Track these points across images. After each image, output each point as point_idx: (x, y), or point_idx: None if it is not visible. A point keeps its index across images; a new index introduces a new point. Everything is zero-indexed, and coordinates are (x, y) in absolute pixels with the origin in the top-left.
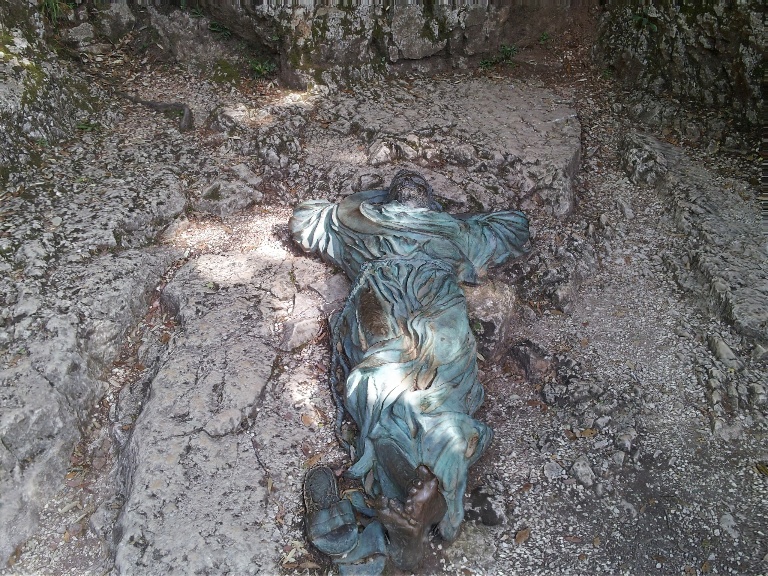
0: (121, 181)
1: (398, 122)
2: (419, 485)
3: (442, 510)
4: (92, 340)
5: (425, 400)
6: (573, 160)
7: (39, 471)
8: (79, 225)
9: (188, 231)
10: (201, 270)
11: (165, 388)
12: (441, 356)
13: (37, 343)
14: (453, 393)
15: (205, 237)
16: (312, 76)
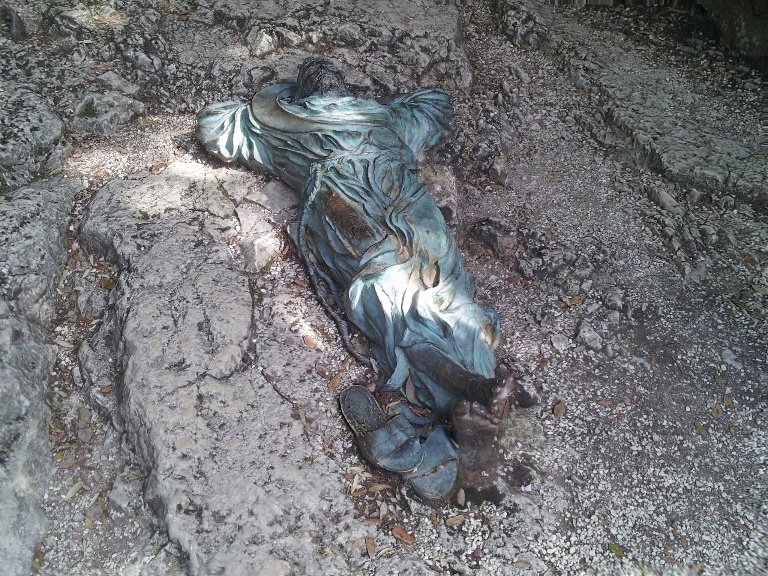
0: None
1: (267, 5)
2: (503, 383)
3: None
4: (22, 300)
5: (437, 297)
6: (457, 29)
7: (24, 460)
8: None
9: (74, 157)
10: (119, 199)
11: (145, 338)
12: (434, 249)
13: None
14: (457, 285)
15: (98, 161)
16: None
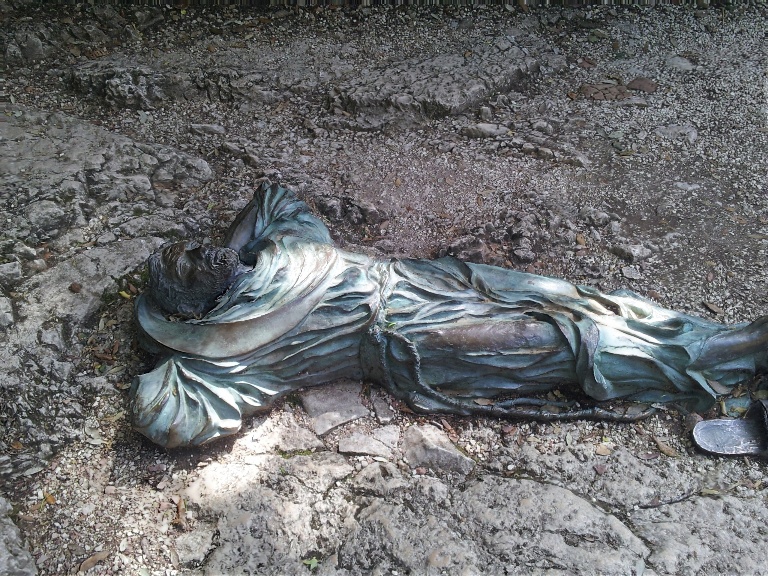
0: None
1: None
2: None
3: None
4: None
5: None
6: None
7: None
8: None
9: None
10: None
11: None
12: (560, 288)
13: None
14: None
15: None
16: None
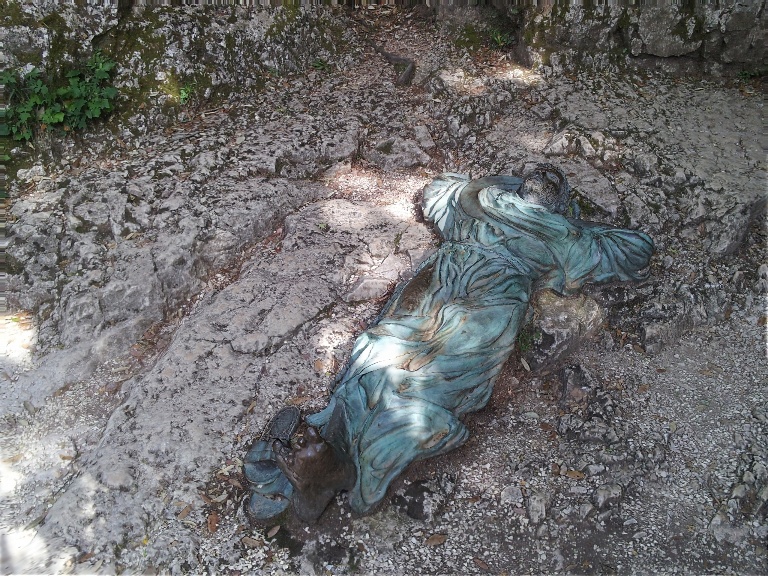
0: (311, 118)
1: (597, 117)
2: (302, 443)
3: (343, 479)
4: (209, 245)
5: (407, 381)
6: None
7: (113, 334)
8: (253, 147)
9: (347, 175)
10: (324, 211)
11: (224, 299)
12: (450, 347)
13: (165, 234)
14: (442, 385)
15: (357, 184)
16: (541, 55)
